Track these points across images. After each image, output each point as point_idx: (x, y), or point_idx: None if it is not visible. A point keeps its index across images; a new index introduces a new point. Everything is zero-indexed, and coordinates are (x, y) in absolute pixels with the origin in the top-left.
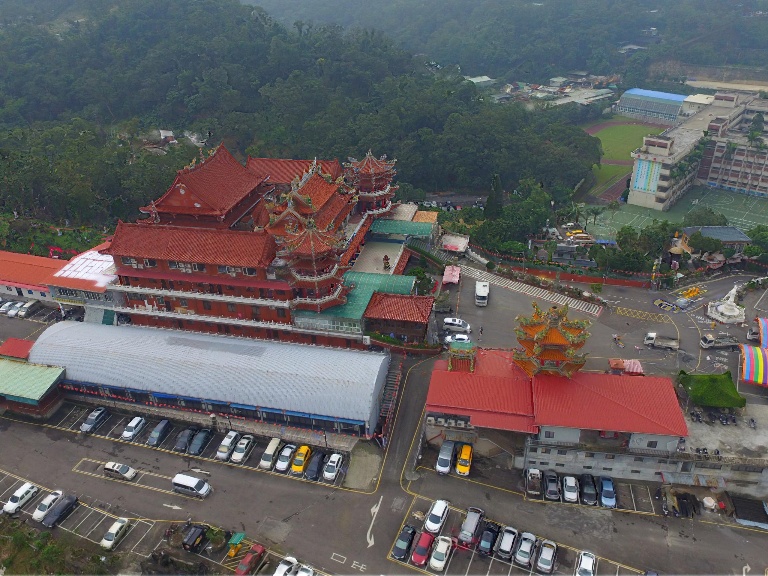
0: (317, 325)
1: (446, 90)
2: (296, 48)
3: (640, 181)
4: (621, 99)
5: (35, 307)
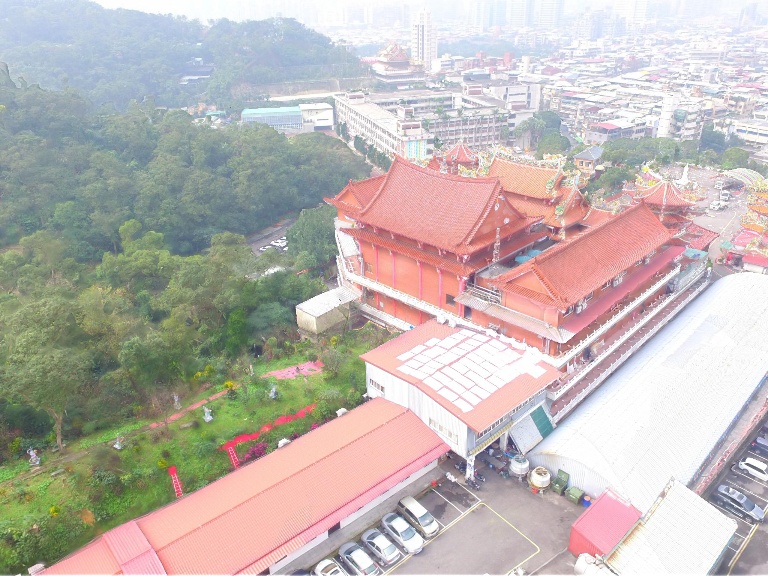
0: None
1: None
2: None
3: None
4: (243, 120)
5: None
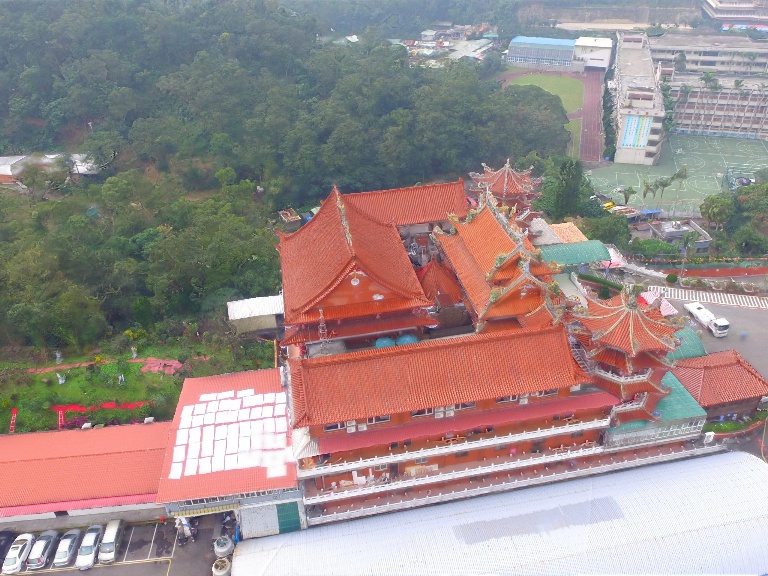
0: (643, 437)
1: (399, 59)
2: (180, 21)
3: (629, 138)
4: (510, 49)
5: (120, 534)
